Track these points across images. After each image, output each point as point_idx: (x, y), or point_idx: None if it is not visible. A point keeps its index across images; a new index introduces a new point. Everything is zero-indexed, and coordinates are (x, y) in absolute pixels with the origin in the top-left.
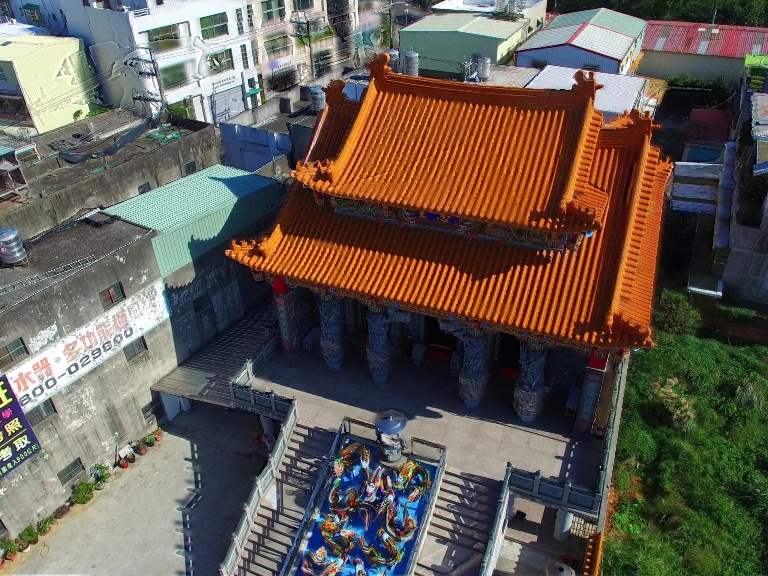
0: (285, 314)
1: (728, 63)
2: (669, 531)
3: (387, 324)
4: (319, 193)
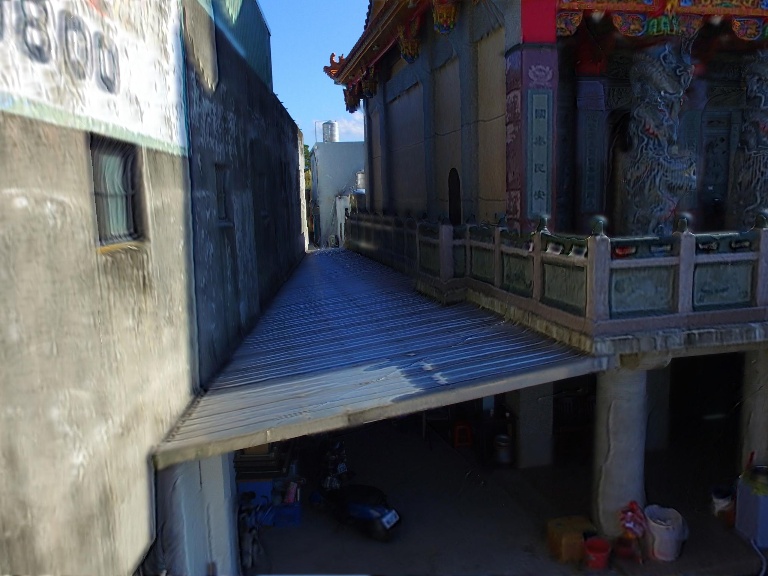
0: (548, 119)
1: None
2: None
3: None
4: None
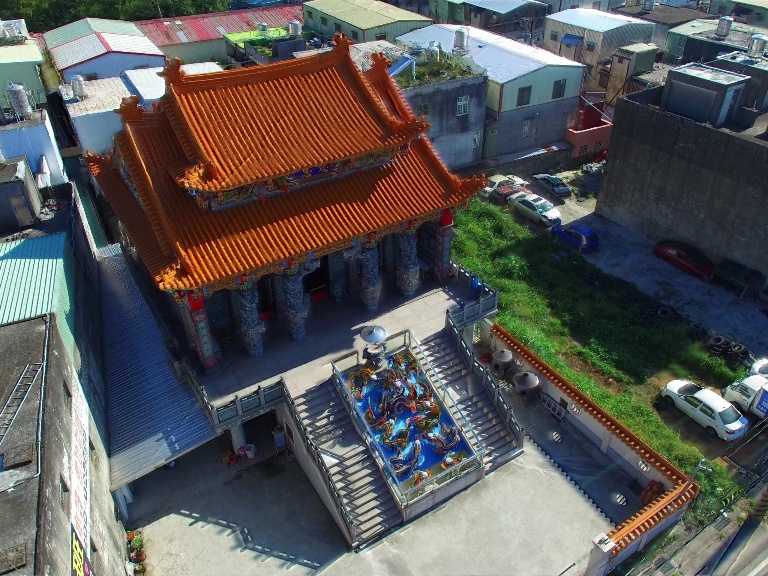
0: (206, 329)
1: (210, 45)
2: (500, 311)
3: (300, 281)
4: (203, 196)
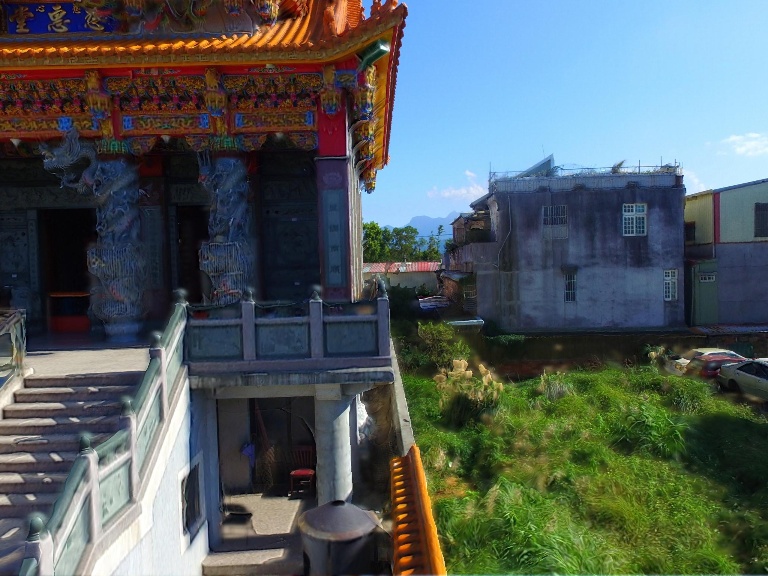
0: None
1: (426, 277)
2: None
3: None
4: None
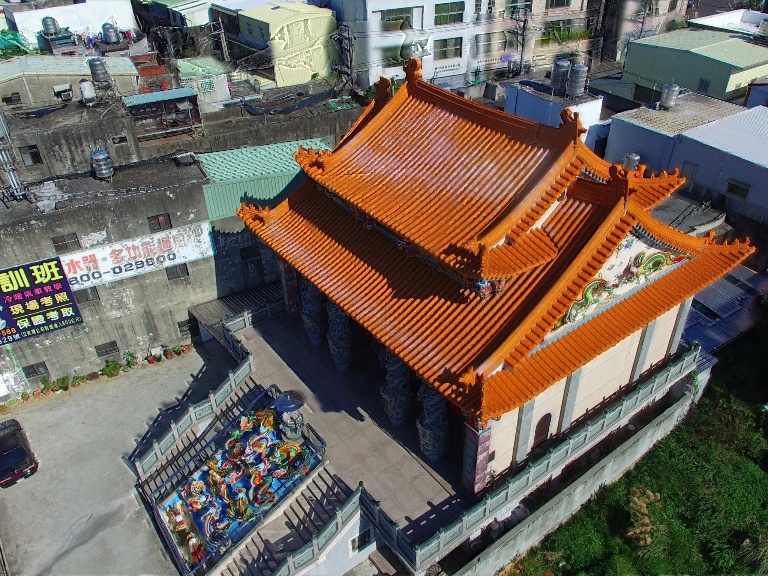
0: (285, 281)
1: None
2: None
3: (345, 317)
4: None
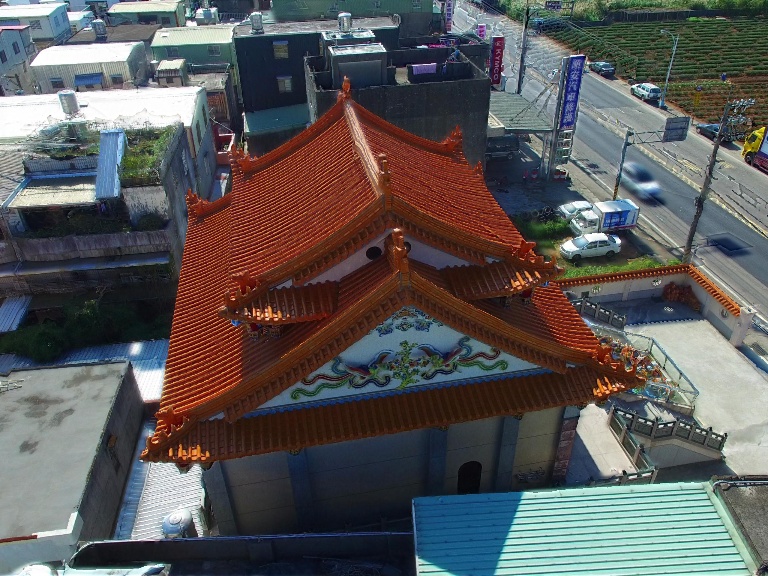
0: None
1: None
2: None
3: None
4: None
